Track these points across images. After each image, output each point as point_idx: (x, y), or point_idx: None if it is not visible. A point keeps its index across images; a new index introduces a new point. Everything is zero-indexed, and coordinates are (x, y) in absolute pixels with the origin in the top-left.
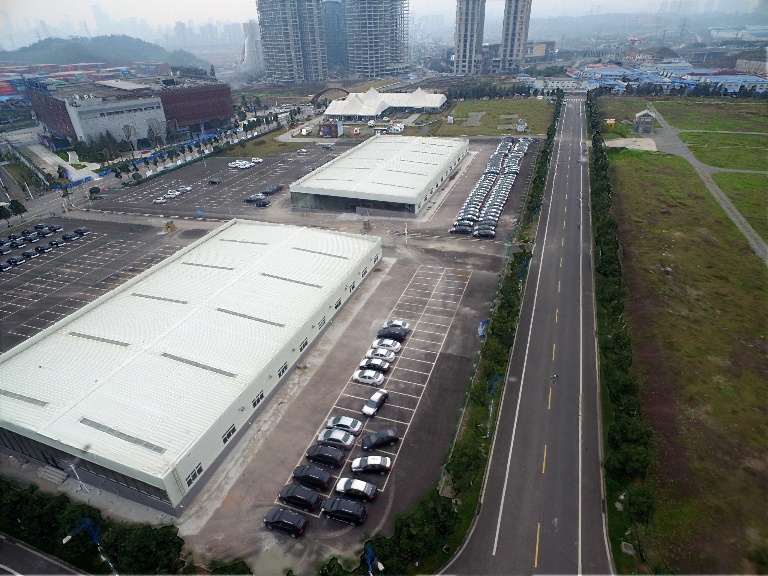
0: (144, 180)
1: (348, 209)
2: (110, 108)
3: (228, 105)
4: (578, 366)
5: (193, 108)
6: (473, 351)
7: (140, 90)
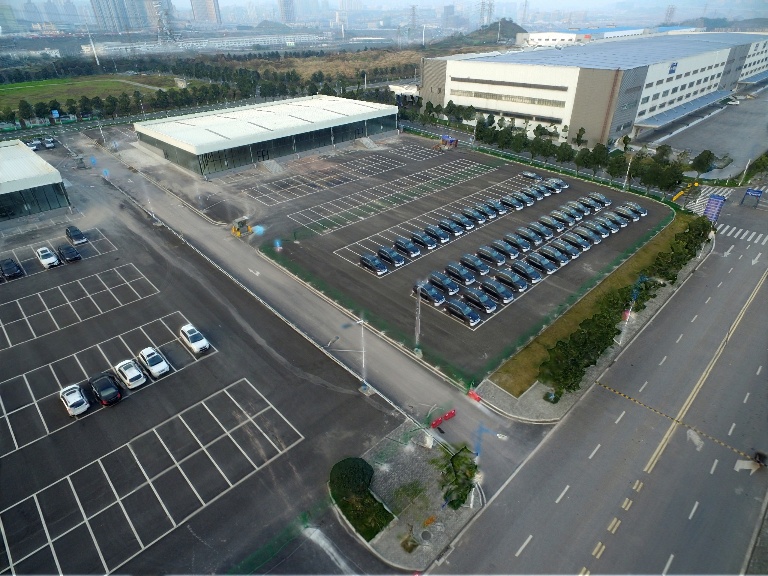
0: None
1: None
2: None
3: None
4: None
5: None
6: None
7: None
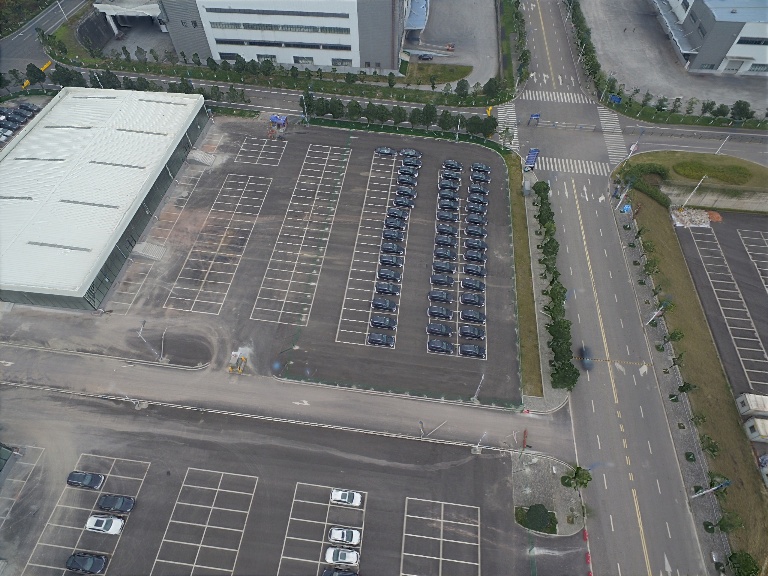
0: None
1: None
2: None
3: None
4: None
5: None
6: None
7: None
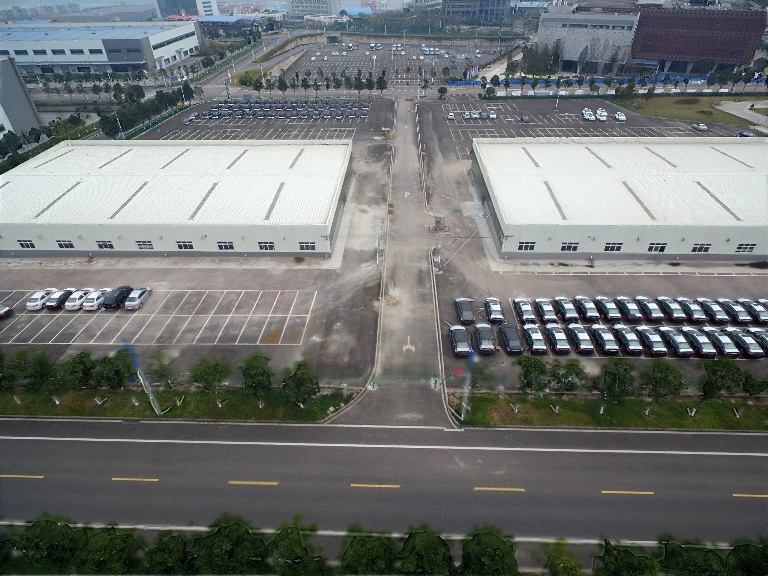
0: (496, 97)
1: (483, 199)
2: (576, 19)
3: (749, 45)
4: None
5: (691, 39)
6: None
7: (649, 6)
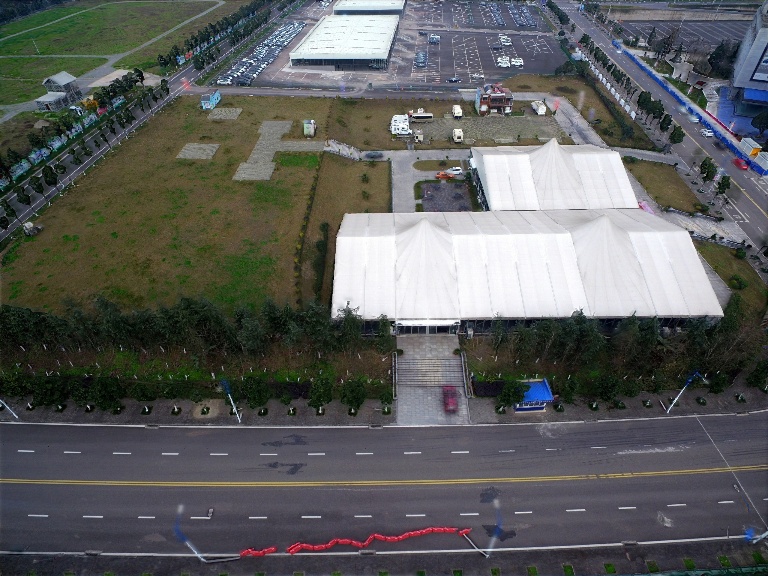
0: None
1: None
2: None
3: None
4: (275, 8)
5: None
6: (300, 7)
7: None
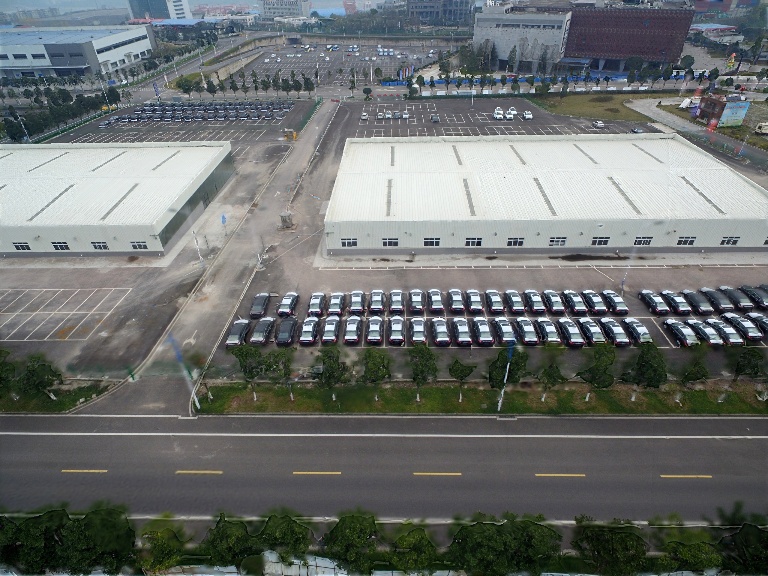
0: (420, 97)
1: None
2: (508, 19)
3: (676, 43)
4: None
5: (622, 38)
6: None
7: (584, 5)
